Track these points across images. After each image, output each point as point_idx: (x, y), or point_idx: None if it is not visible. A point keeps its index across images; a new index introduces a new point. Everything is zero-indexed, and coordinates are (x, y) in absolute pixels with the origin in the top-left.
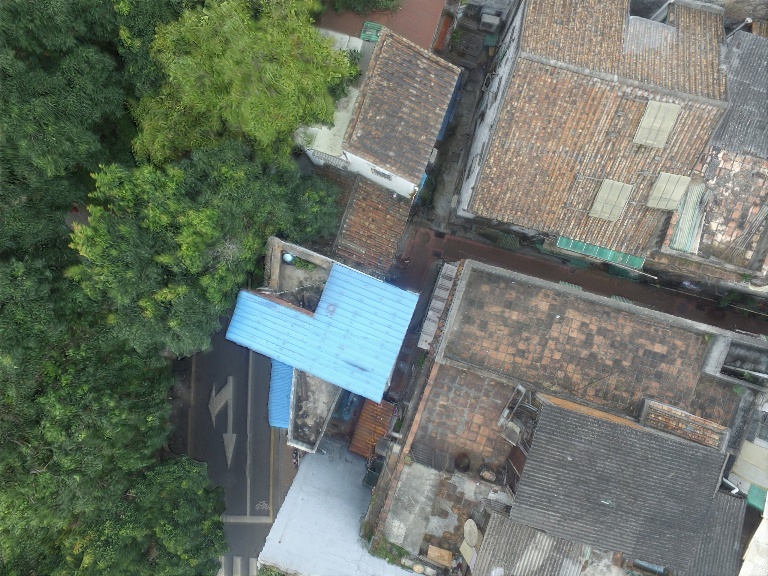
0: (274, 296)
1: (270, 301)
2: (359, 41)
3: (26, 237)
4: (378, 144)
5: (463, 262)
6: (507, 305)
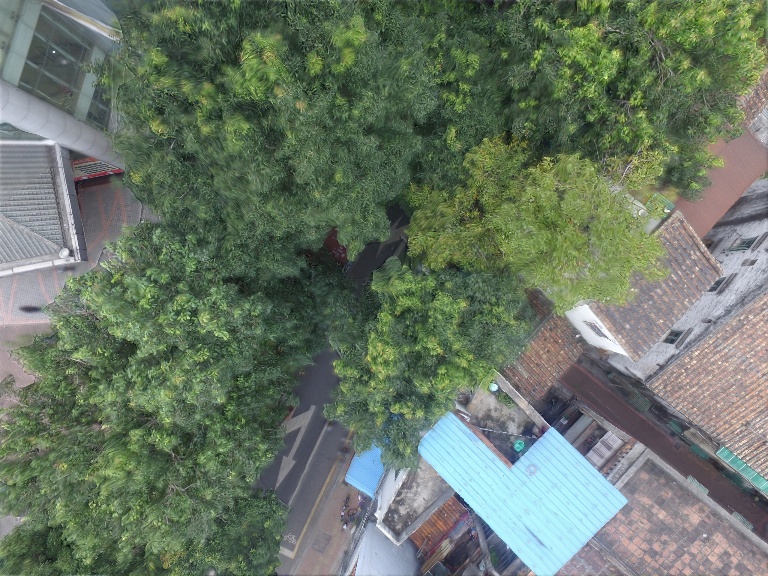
0: (480, 431)
1: (474, 434)
2: None
3: (268, 271)
4: (620, 313)
5: (633, 442)
6: (659, 502)
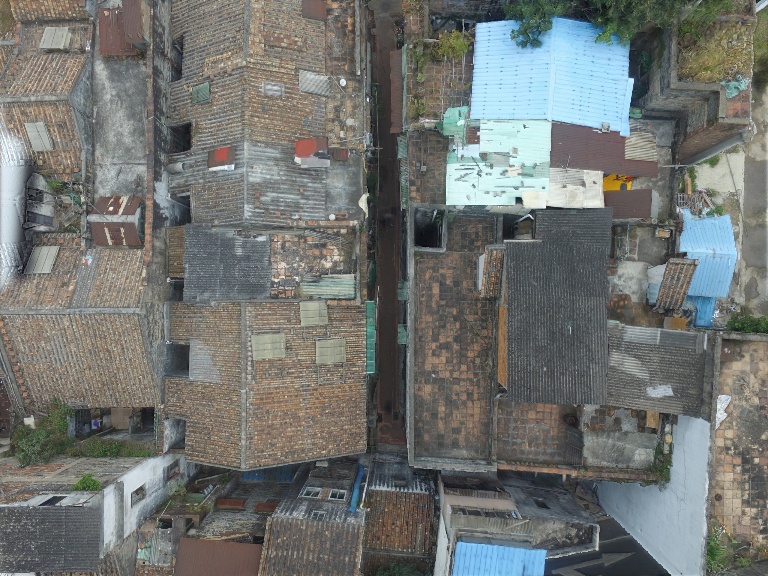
0: None
1: None
2: None
3: None
4: (342, 573)
5: None
6: (435, 417)
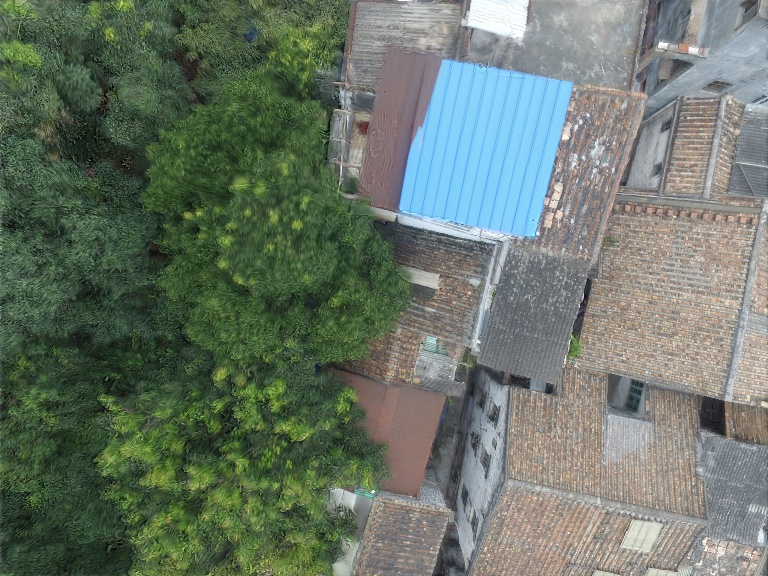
0: None
1: None
2: (353, 495)
3: None
4: None
5: None
6: None
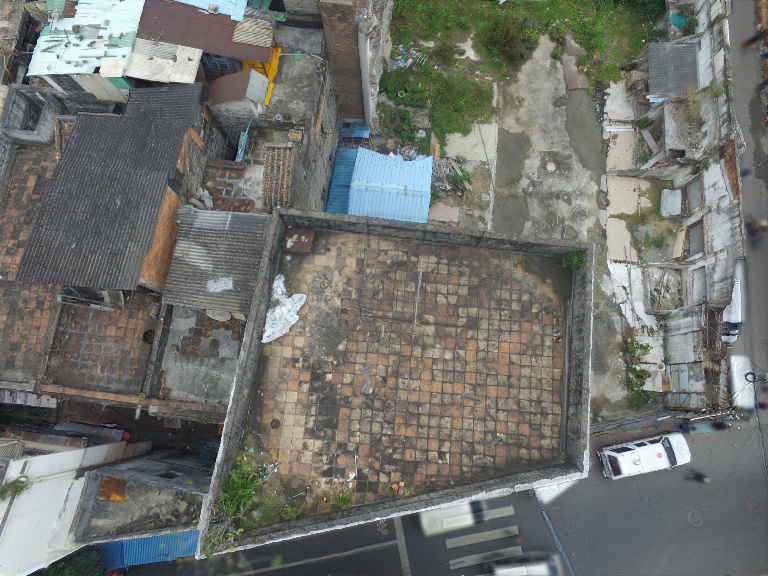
0: None
1: None
2: None
3: None
4: None
5: None
6: None
